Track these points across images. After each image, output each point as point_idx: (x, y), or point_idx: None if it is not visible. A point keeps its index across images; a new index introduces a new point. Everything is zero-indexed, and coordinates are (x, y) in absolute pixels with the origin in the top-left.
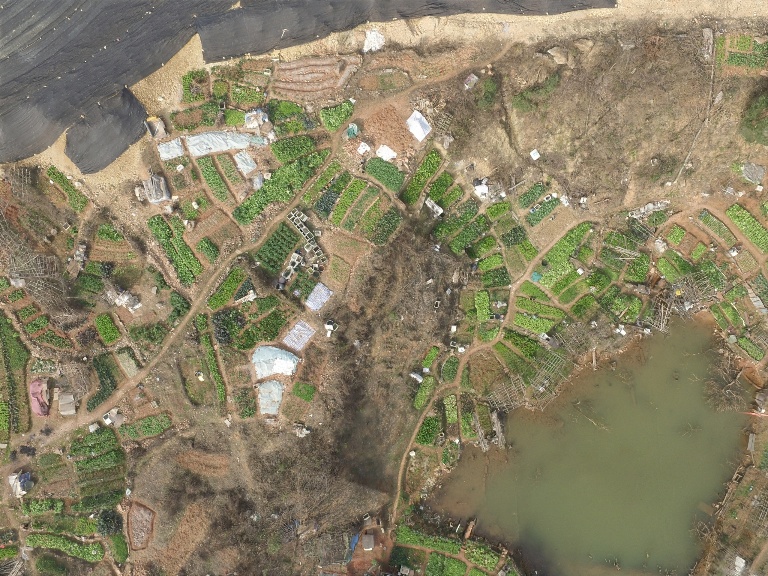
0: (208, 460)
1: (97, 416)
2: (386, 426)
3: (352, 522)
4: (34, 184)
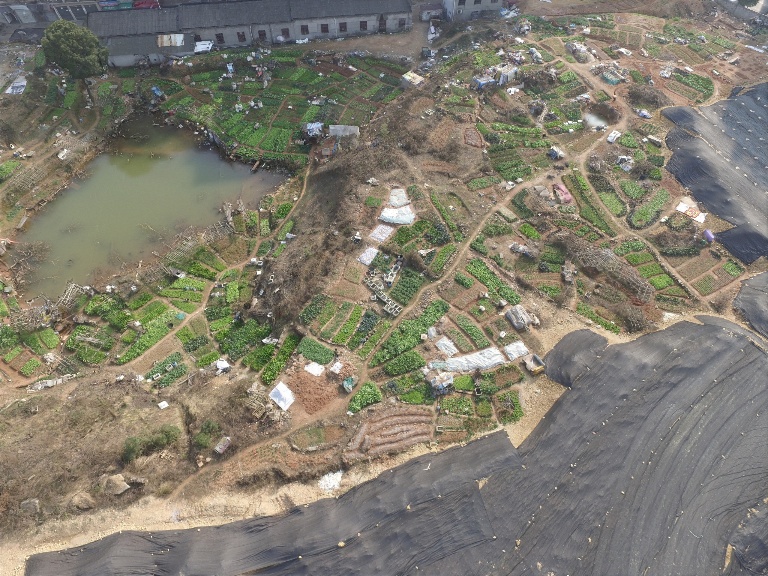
0: (436, 168)
1: (520, 186)
2: None
3: None
4: (626, 319)
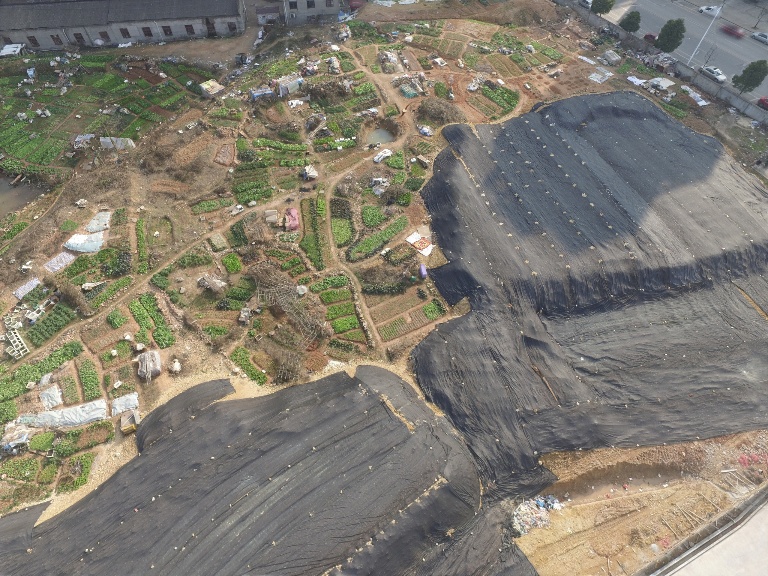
0: (167, 188)
1: (250, 210)
2: None
3: None
4: None
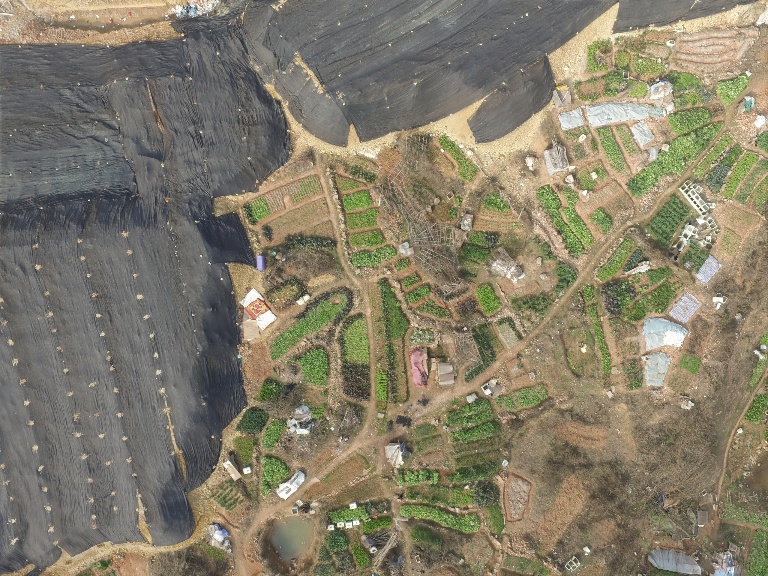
0: (586, 432)
1: (474, 387)
2: (728, 402)
3: (692, 498)
4: (426, 152)
